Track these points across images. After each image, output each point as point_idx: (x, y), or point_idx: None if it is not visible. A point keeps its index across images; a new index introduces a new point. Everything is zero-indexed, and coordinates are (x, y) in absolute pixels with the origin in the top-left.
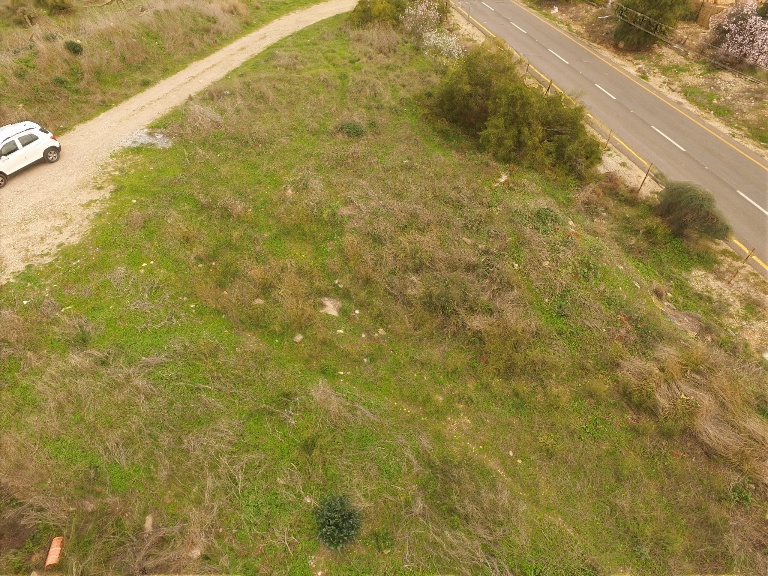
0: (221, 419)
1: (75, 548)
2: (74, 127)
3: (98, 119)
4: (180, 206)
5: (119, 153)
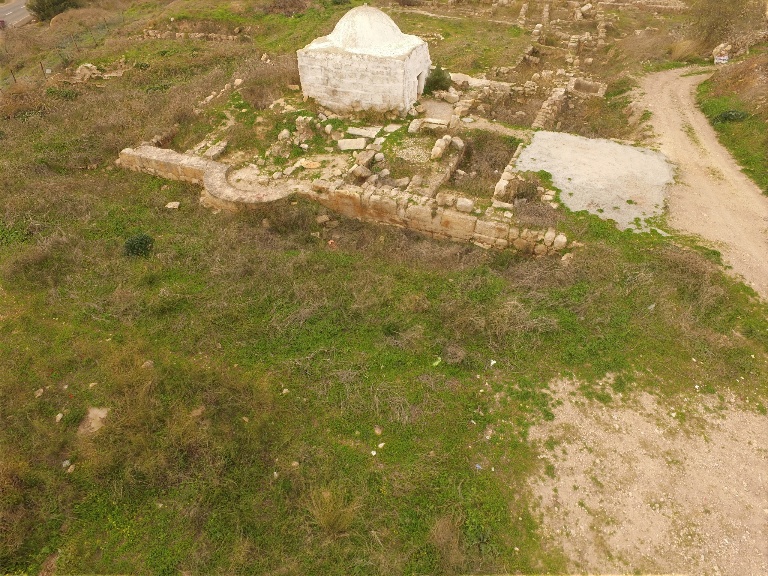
0: (225, 285)
1: None
2: None
3: None
4: None
5: None
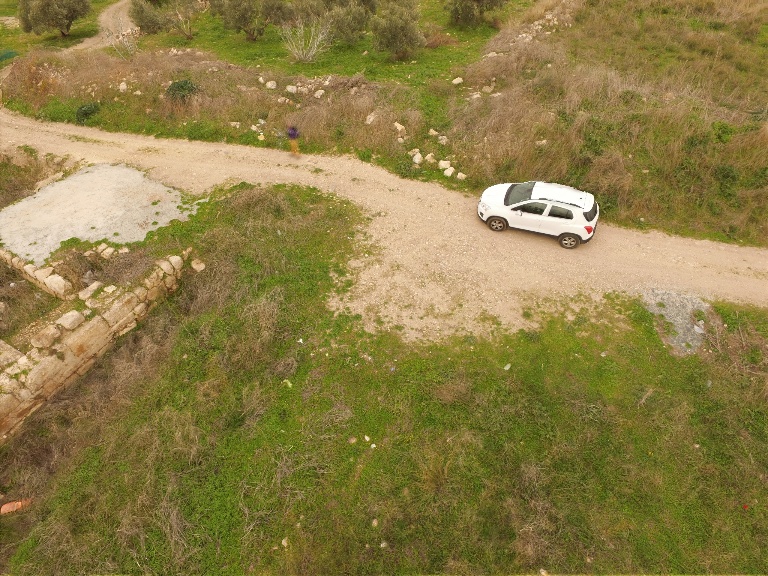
0: None
1: (3, 526)
2: (651, 230)
3: (691, 242)
4: (513, 436)
5: (621, 300)
